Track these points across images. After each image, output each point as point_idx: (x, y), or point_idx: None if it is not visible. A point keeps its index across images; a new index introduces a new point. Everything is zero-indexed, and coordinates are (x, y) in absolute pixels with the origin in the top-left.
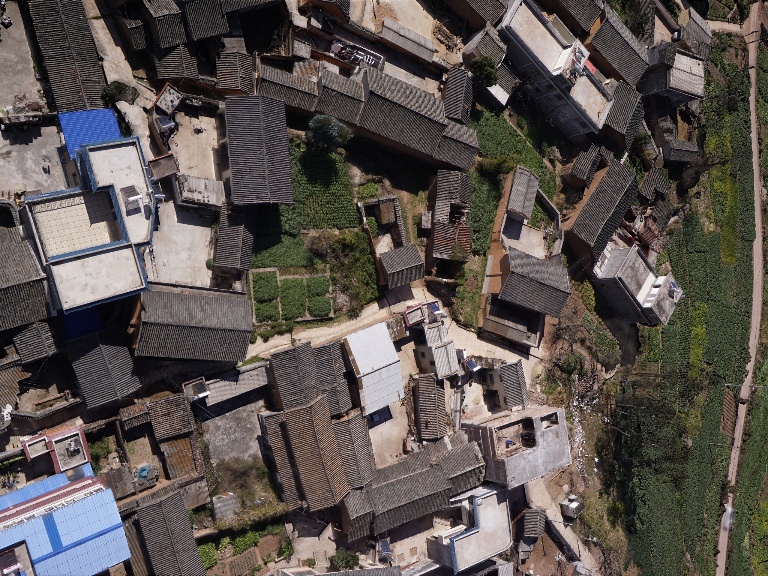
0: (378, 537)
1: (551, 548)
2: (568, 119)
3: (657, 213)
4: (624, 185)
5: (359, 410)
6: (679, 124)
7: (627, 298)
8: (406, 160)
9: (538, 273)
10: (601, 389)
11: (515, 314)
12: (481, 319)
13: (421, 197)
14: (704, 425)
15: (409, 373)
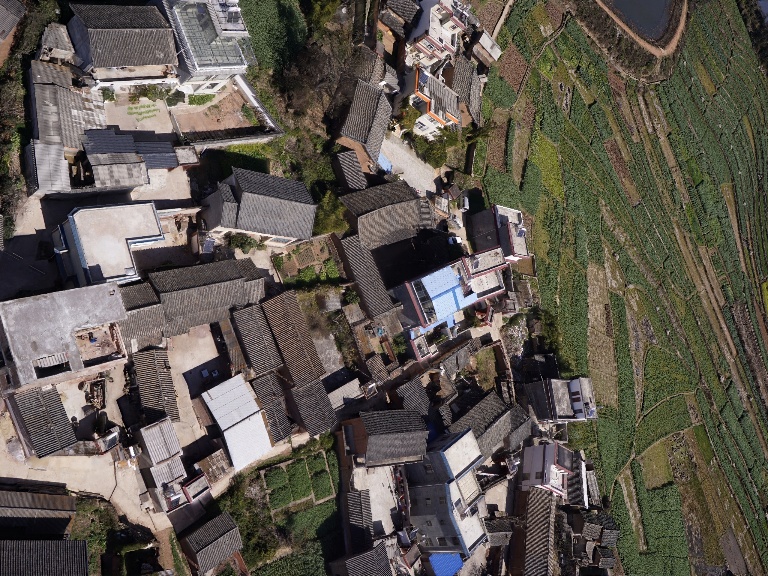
0: None
1: None
2: None
3: None
4: None
5: None
6: None
7: None
8: None
9: None
10: None
11: (2, 534)
12: None
13: None
14: None
15: None
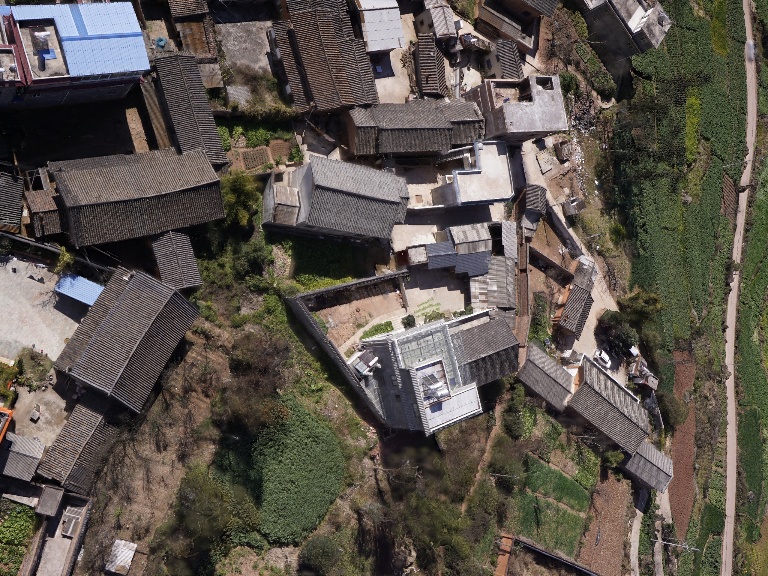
0: (383, 156)
1: (554, 241)
2: None
3: None
4: None
5: None
6: None
7: (618, 26)
8: None
9: None
10: (598, 117)
11: None
12: (477, 11)
13: None
14: (704, 197)
15: (409, 40)
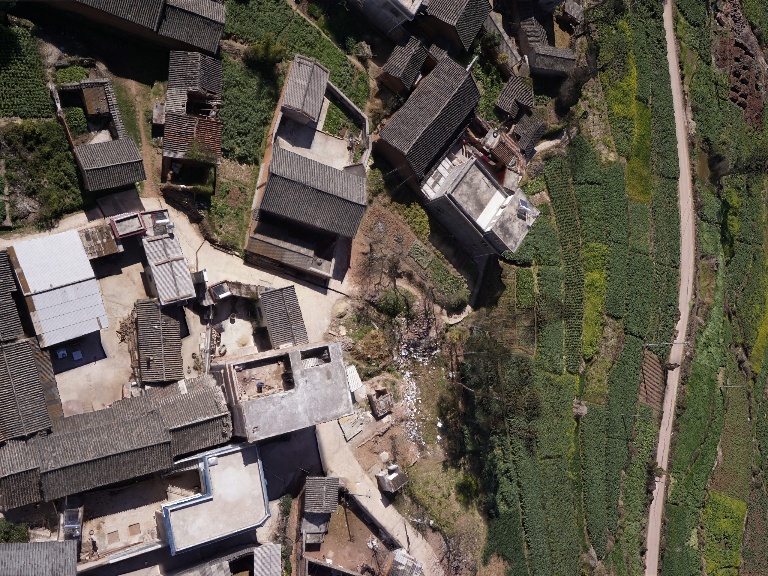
0: (53, 504)
1: (361, 532)
2: (377, 7)
3: (521, 130)
4: (455, 85)
5: (35, 340)
6: (557, 33)
7: (466, 222)
8: (136, 44)
9: (317, 179)
10: (443, 337)
11: (300, 236)
12: (247, 239)
13: (158, 89)
14: (613, 392)
15: (134, 302)
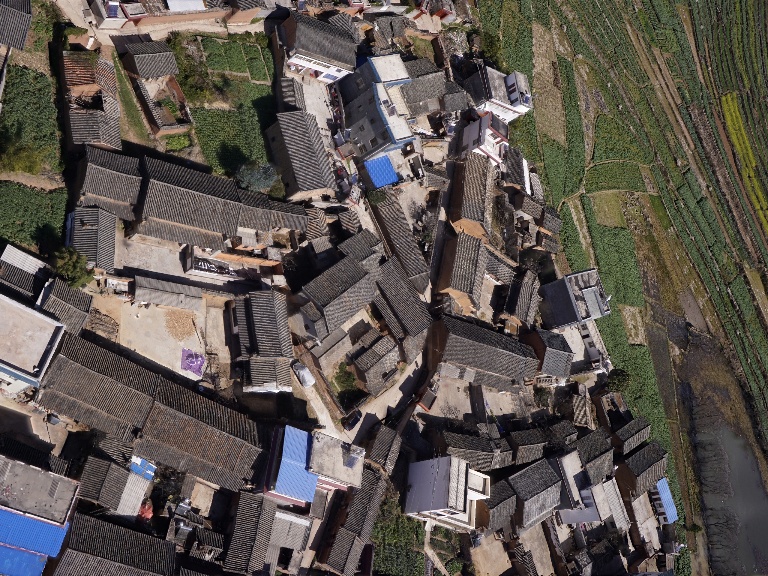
0: None
1: None
2: None
3: None
4: None
5: None
6: None
7: None
8: None
9: None
10: None
11: None
12: None
13: None
14: None
15: None
